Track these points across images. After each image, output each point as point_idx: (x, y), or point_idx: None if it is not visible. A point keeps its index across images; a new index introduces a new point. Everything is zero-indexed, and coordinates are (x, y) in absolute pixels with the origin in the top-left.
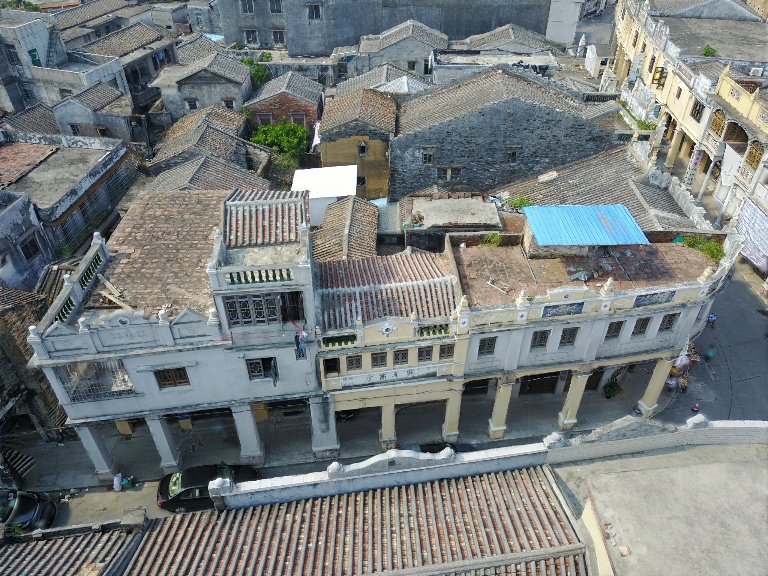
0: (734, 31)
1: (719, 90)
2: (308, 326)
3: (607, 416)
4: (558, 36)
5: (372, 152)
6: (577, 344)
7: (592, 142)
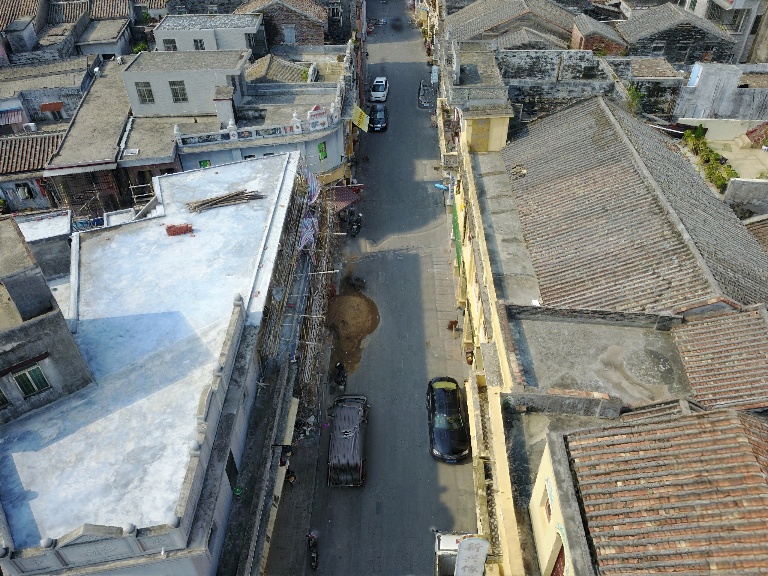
0: None
1: None
2: None
3: None
4: None
5: None
6: None
7: None
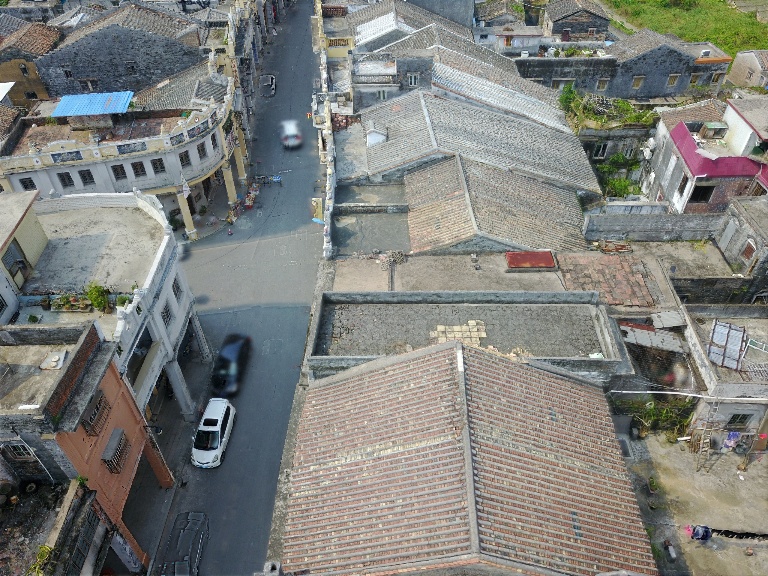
0: None
1: None
2: None
3: None
4: None
5: (32, 72)
6: (96, 182)
7: (187, 56)
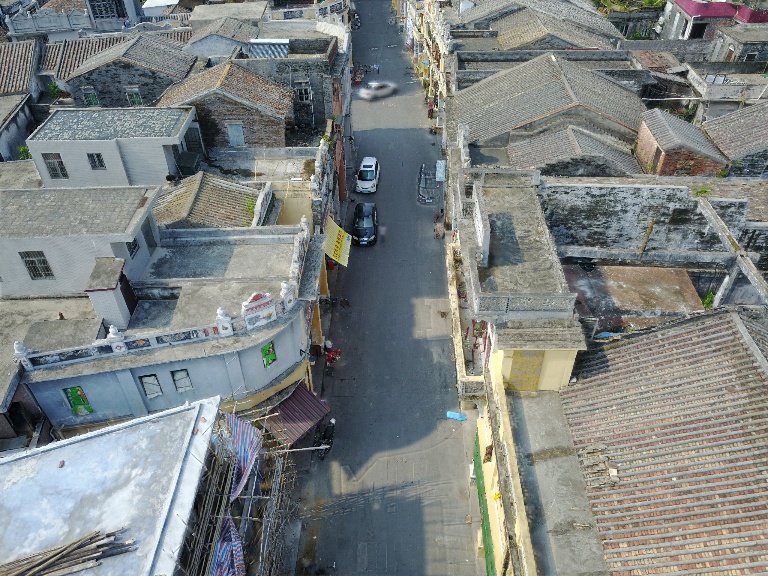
0: None
1: None
2: (130, 19)
3: None
4: None
5: None
6: None
7: None
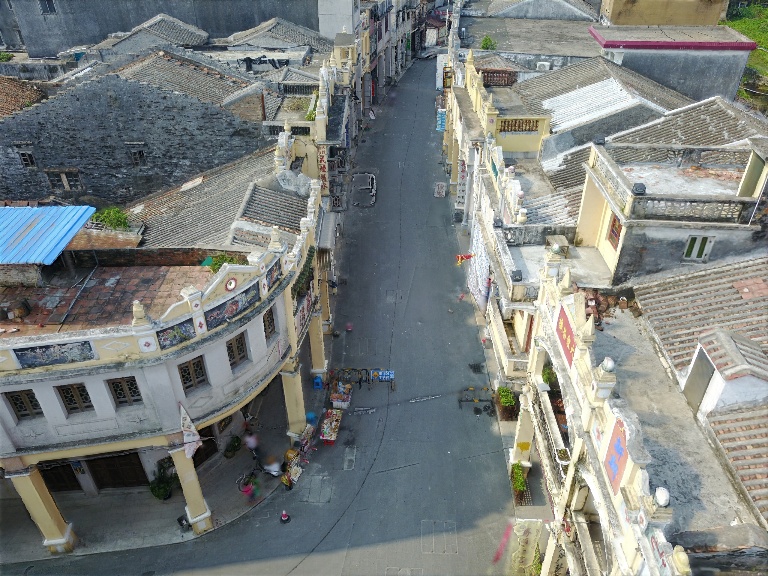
0: (554, 29)
1: (466, 82)
2: None
3: (142, 529)
4: (334, 32)
5: None
6: None
7: (238, 137)
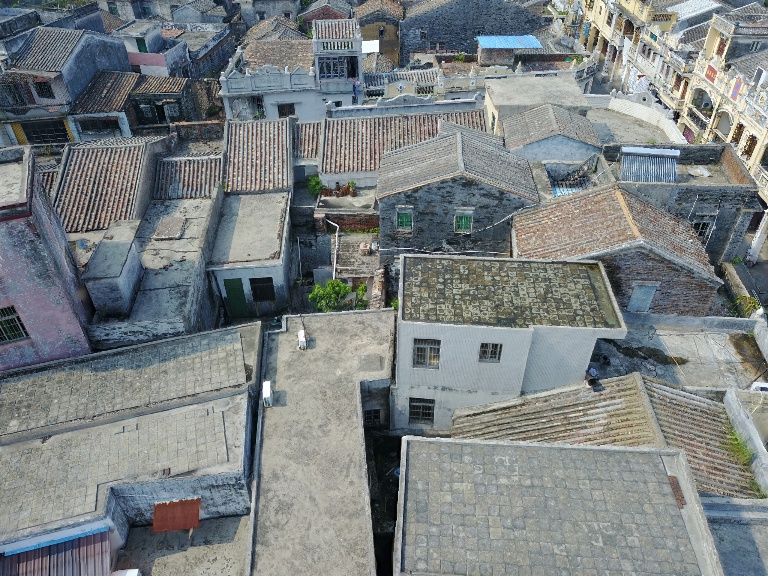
0: None
1: (620, 0)
2: (360, 80)
3: None
4: None
5: (388, 34)
6: None
7: (528, 24)
